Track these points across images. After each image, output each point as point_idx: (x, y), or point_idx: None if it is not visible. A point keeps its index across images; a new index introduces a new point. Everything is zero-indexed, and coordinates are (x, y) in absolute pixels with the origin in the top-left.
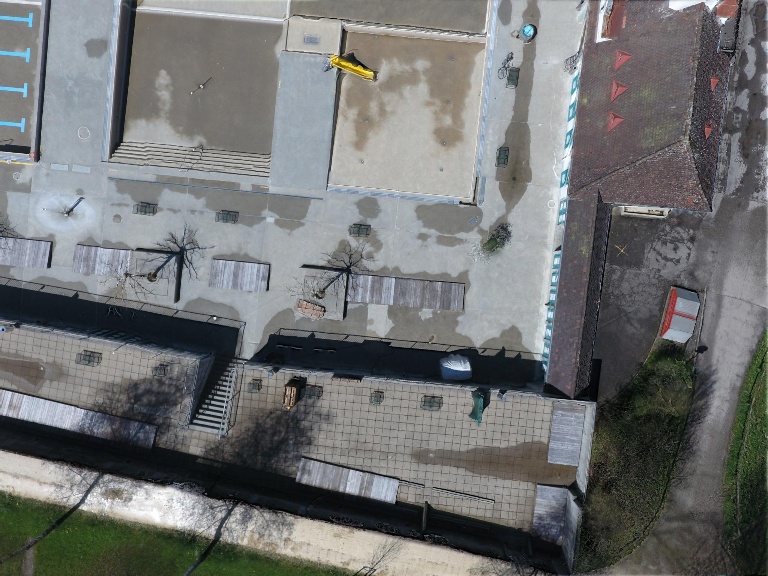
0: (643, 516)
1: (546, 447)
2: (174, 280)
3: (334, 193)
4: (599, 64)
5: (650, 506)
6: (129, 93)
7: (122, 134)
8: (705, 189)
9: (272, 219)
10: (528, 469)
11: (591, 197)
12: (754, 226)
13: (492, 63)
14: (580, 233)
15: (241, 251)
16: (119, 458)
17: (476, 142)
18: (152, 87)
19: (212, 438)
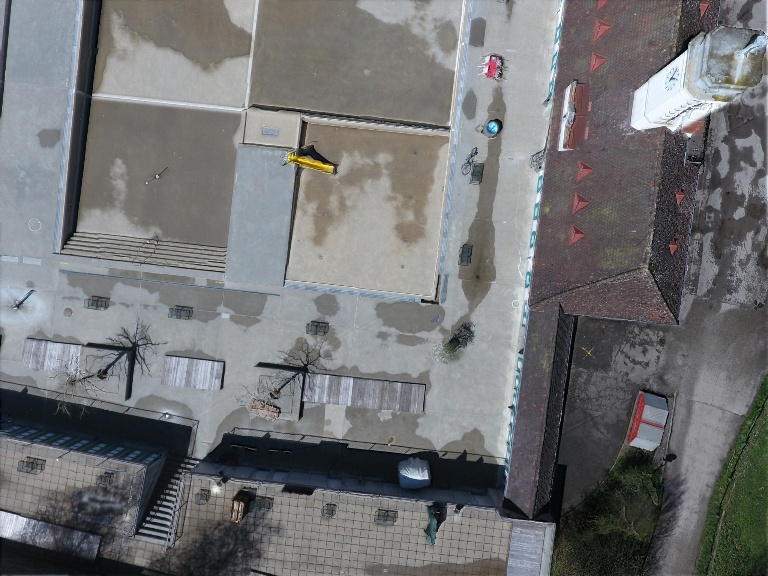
0: None
1: (505, 564)
2: (125, 377)
3: (291, 289)
4: (561, 173)
5: None
6: None
7: (76, 223)
8: (671, 304)
9: (227, 315)
10: None
11: (552, 310)
12: (726, 329)
13: (456, 158)
14: (541, 346)
15: (195, 347)
16: (61, 570)
17: (439, 239)
18: (107, 176)
19: (158, 549)
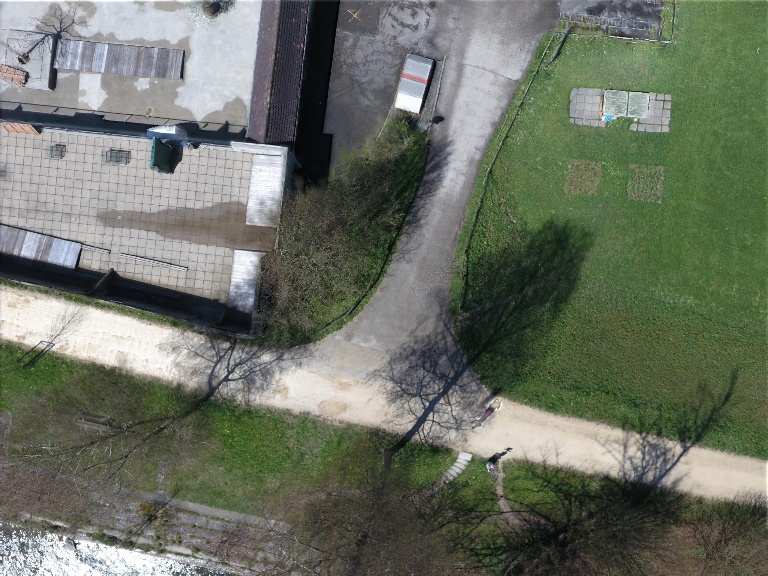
0: (356, 289)
1: (245, 208)
2: None
3: None
4: None
5: (365, 279)
6: None
7: None
8: None
9: None
10: (225, 233)
11: None
12: None
13: None
14: None
15: None
16: None
17: None
18: None
19: None
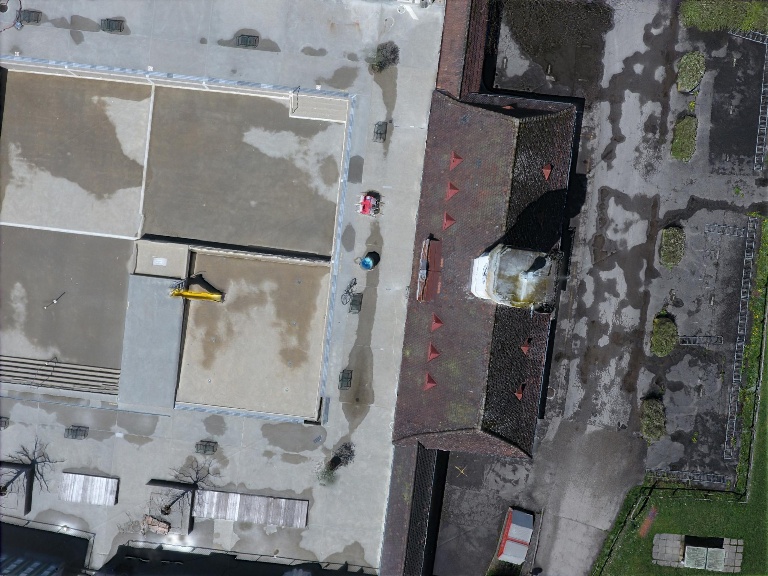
0: None
1: None
2: (23, 494)
3: (181, 411)
4: (419, 321)
5: None
6: None
7: None
8: (521, 443)
9: (121, 435)
10: None
11: (412, 447)
12: (591, 449)
13: (336, 288)
14: (403, 478)
15: (91, 465)
16: None
17: (320, 363)
18: (7, 300)
19: None
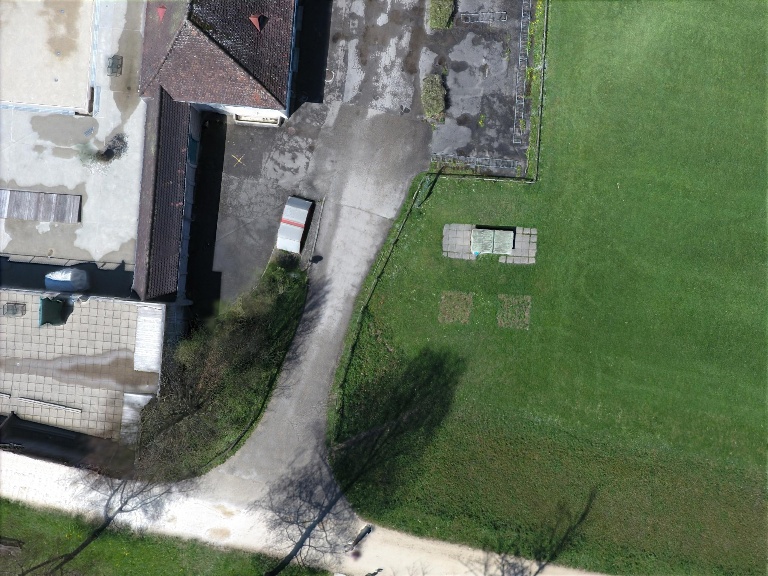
0: (238, 425)
1: (132, 354)
2: None
3: None
4: None
5: (246, 416)
6: None
7: None
8: (268, 84)
9: None
10: (116, 377)
11: (156, 94)
12: (374, 134)
13: None
14: (151, 132)
15: None
16: None
17: (90, 51)
18: None
19: None
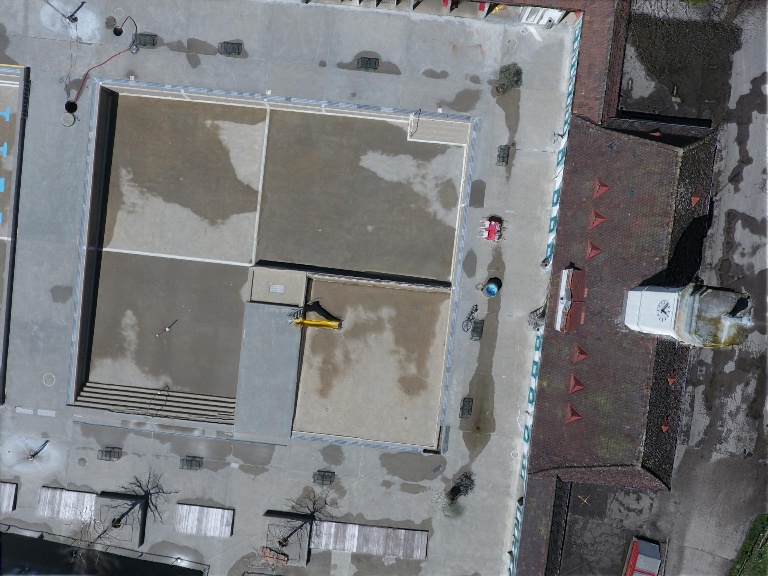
0: None
1: None
2: (138, 526)
3: (298, 440)
4: (558, 352)
5: None
6: (95, 332)
7: (88, 372)
8: (663, 475)
9: (236, 465)
10: None
11: (550, 480)
12: (717, 477)
13: (457, 315)
14: (539, 512)
15: (205, 495)
16: None
17: (440, 391)
18: (118, 327)
19: None
